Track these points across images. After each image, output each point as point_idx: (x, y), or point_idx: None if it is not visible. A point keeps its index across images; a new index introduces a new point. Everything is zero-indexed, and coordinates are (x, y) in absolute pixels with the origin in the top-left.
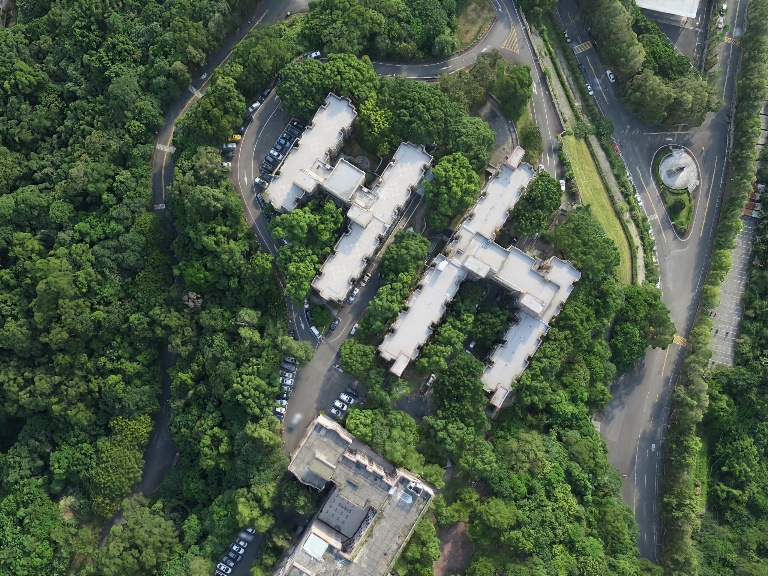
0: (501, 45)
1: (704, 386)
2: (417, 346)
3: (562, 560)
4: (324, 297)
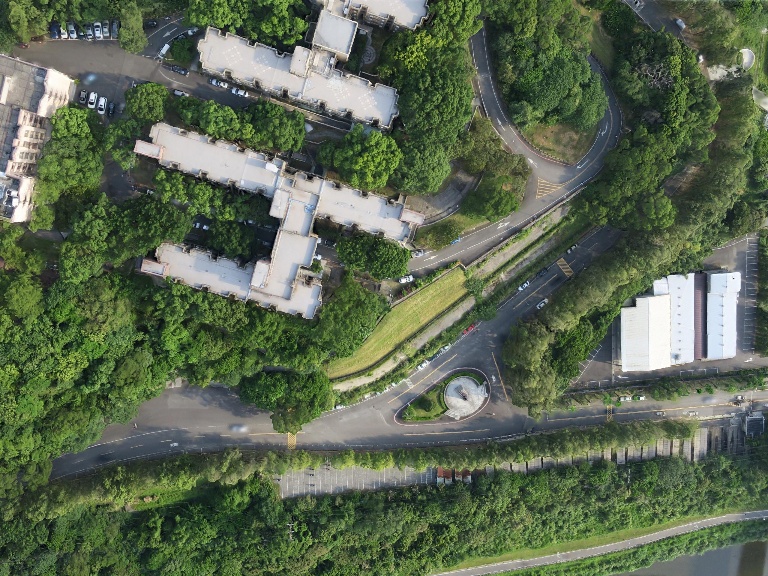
0: (540, 177)
1: (245, 474)
2: (176, 163)
3: (2, 378)
4: (199, 45)
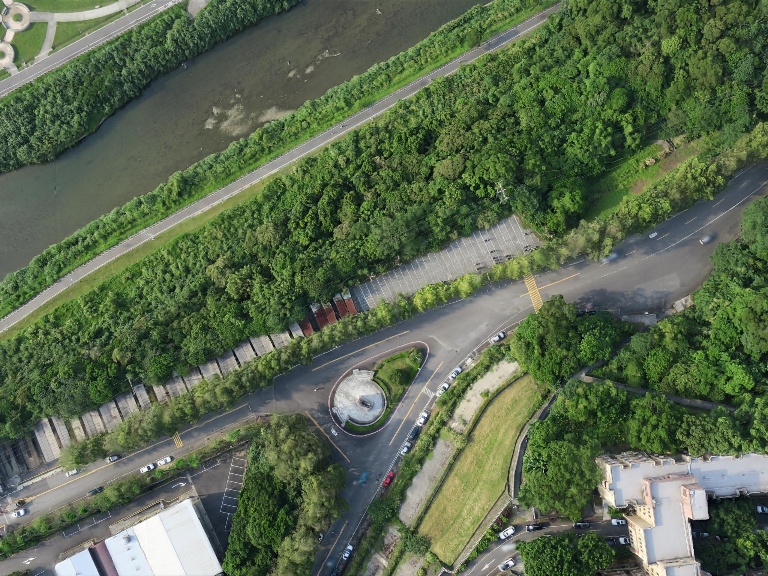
0: None
1: None
2: None
3: None
4: None
